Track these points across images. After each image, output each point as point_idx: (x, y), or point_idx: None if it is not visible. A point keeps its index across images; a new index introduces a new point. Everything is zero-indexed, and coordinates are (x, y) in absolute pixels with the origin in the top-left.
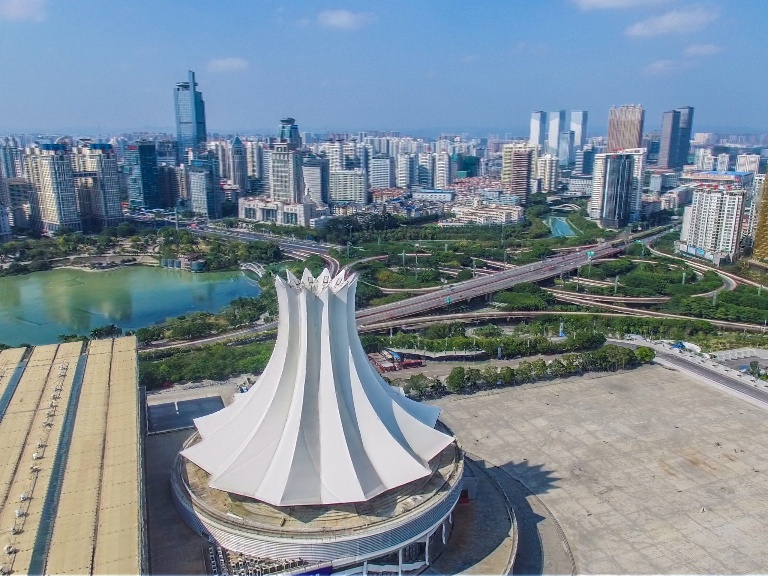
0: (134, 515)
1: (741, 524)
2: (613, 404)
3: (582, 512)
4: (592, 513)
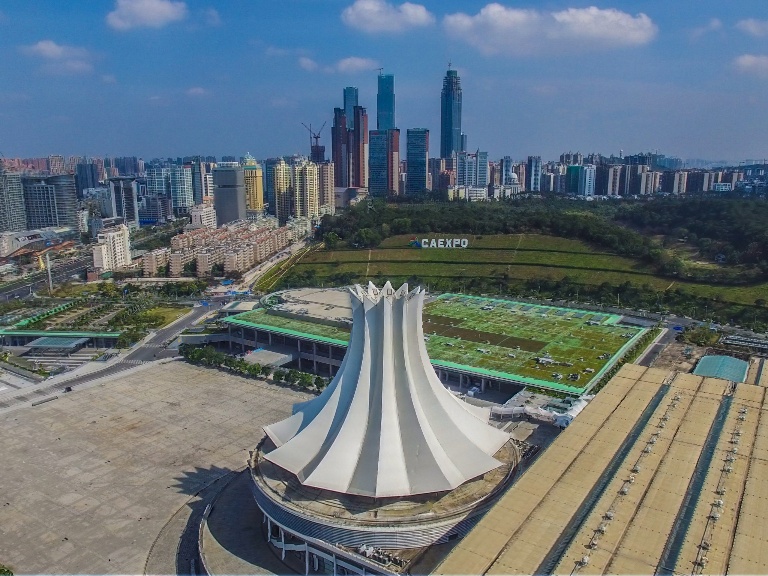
0: (582, 415)
1: (218, 411)
2: (2, 470)
3: (244, 452)
4: (243, 449)
